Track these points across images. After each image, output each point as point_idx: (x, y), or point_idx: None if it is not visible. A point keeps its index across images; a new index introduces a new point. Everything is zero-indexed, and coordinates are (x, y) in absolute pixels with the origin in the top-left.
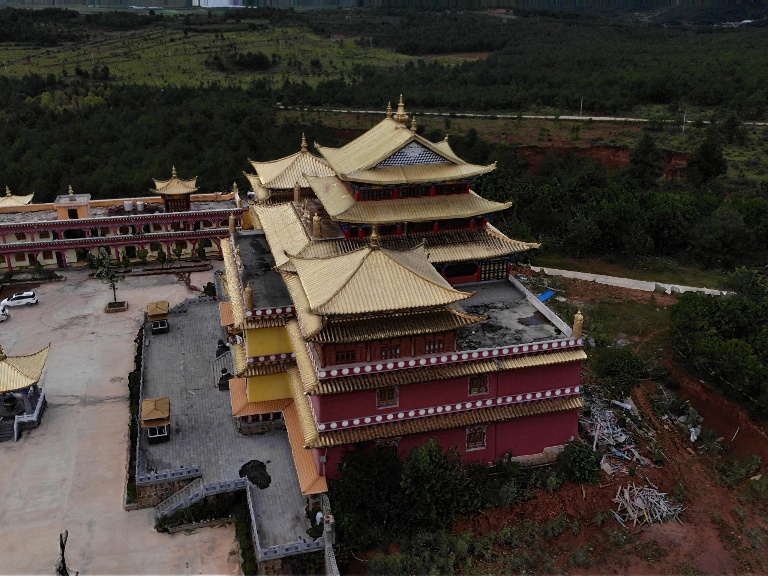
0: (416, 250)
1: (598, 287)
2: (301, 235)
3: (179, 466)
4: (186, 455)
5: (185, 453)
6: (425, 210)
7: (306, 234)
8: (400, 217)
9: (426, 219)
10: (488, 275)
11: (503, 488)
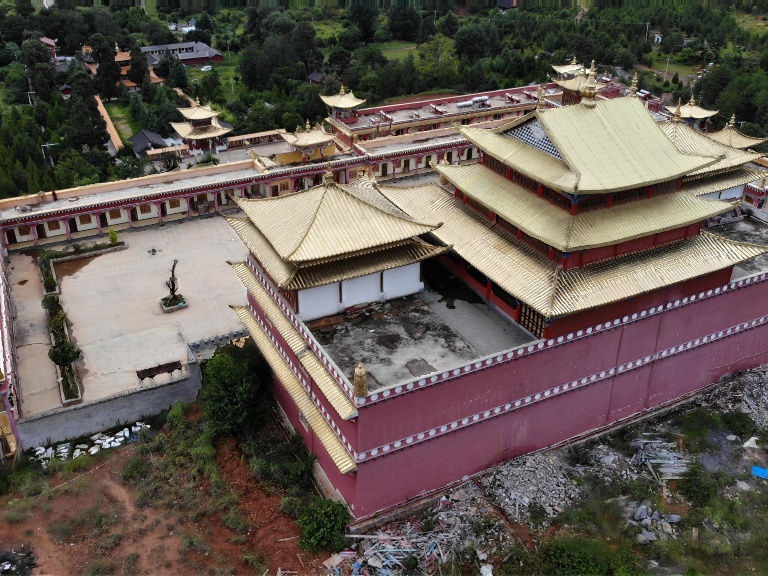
0: (414, 225)
1: None
2: None
3: None
4: None
5: None
6: (510, 205)
7: None
8: (483, 198)
9: (498, 214)
10: (528, 322)
11: (255, 457)
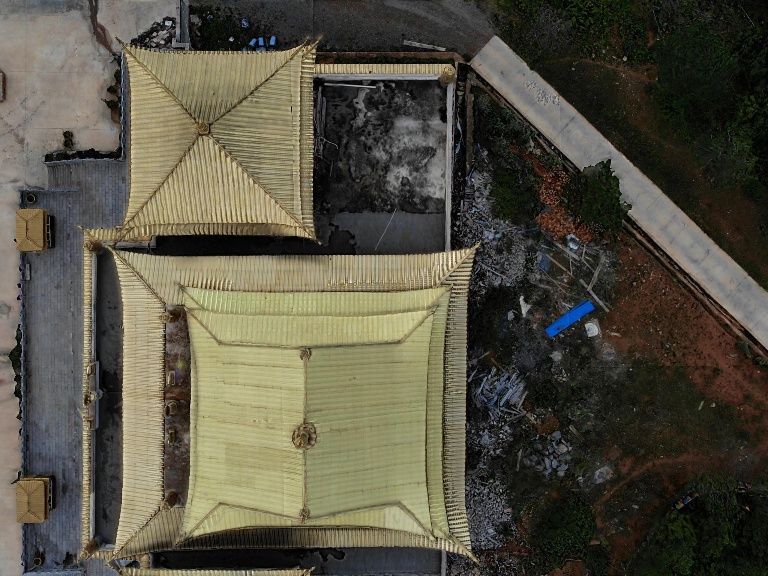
0: None
1: (665, 306)
2: (158, 462)
3: (65, 552)
4: (72, 535)
5: (71, 532)
6: None
7: (163, 470)
8: None
9: (323, 528)
10: None
11: None
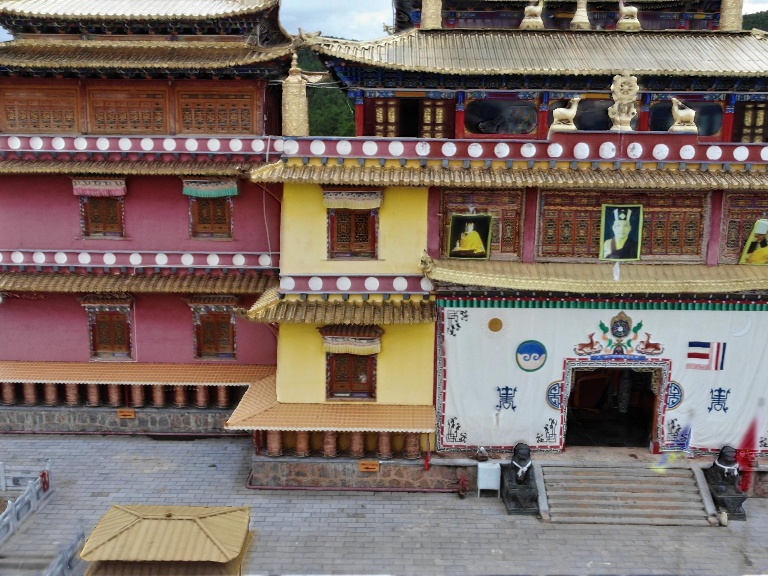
0: None
1: None
2: (682, 39)
3: None
4: None
5: None
6: None
7: (690, 35)
8: None
9: None
10: None
11: None
